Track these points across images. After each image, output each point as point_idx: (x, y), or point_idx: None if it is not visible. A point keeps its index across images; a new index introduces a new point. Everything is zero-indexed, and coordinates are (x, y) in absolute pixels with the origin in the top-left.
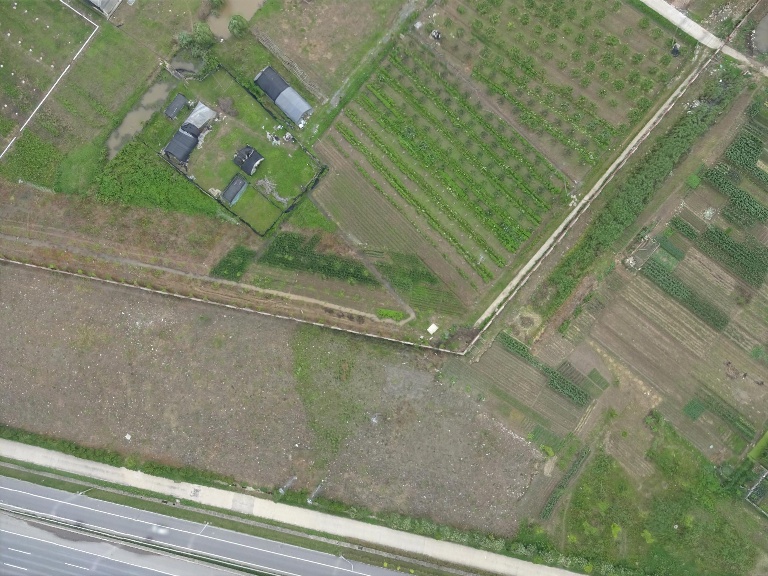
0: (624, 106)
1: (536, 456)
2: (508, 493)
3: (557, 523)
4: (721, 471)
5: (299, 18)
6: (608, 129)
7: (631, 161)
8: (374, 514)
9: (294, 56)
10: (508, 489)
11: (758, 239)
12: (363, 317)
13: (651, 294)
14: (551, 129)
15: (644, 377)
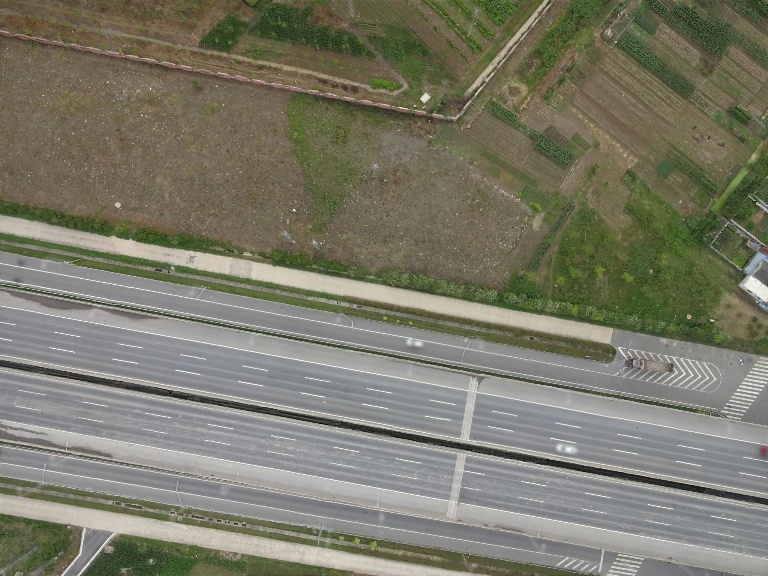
0: None
1: (526, 211)
2: (500, 245)
3: (545, 273)
4: (689, 222)
5: None
6: None
7: None
8: (372, 274)
9: None
10: (500, 241)
11: (719, 16)
12: (357, 87)
13: (627, 65)
14: None
15: (621, 141)
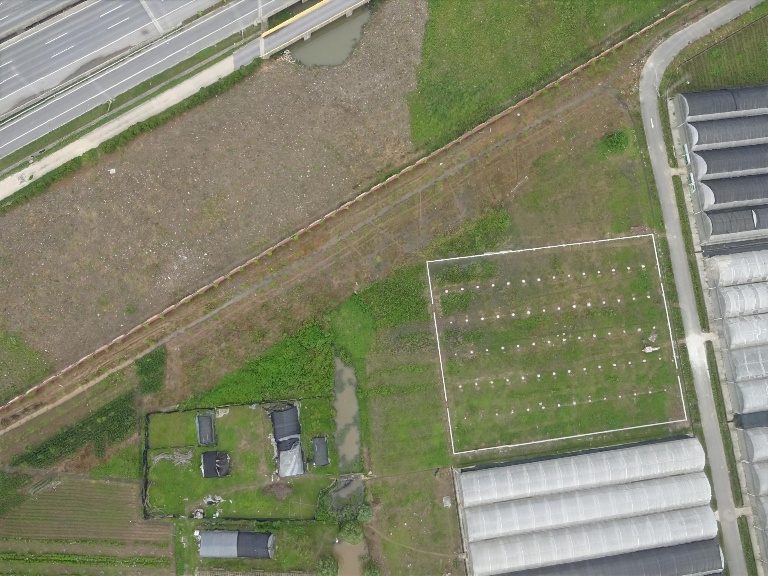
0: None
1: None
2: None
3: None
4: None
5: None
6: None
7: None
8: None
9: None
10: None
11: None
12: (5, 427)
13: None
14: None
15: None
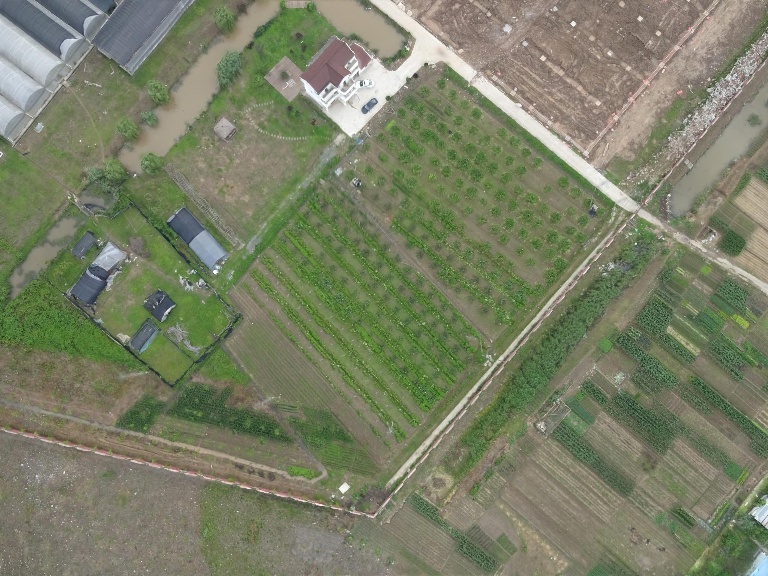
0: (541, 265)
1: None
2: None
3: None
4: None
5: (216, 157)
6: (525, 289)
7: (546, 322)
8: None
9: (210, 197)
10: None
11: (665, 405)
12: (274, 474)
13: (561, 458)
14: (469, 286)
15: (551, 541)
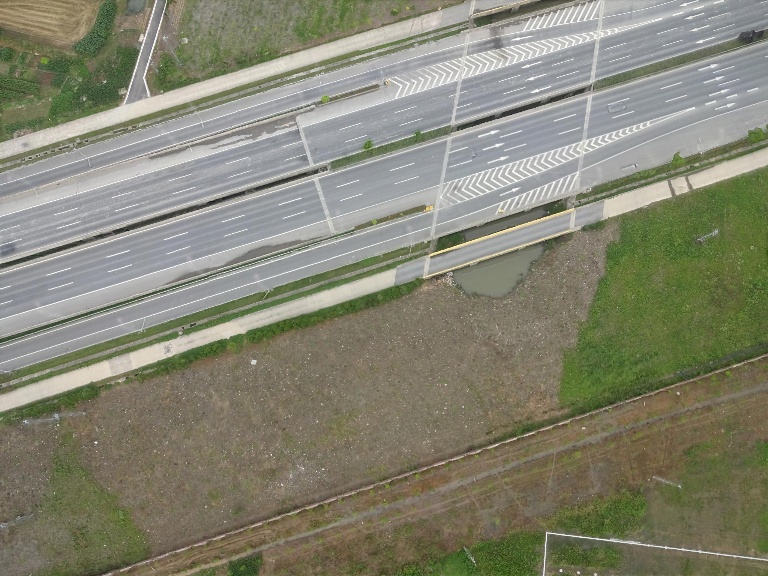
0: None
1: None
2: None
3: None
4: None
5: None
6: None
7: None
8: (0, 422)
9: None
10: None
11: None
12: None
13: None
14: None
15: None
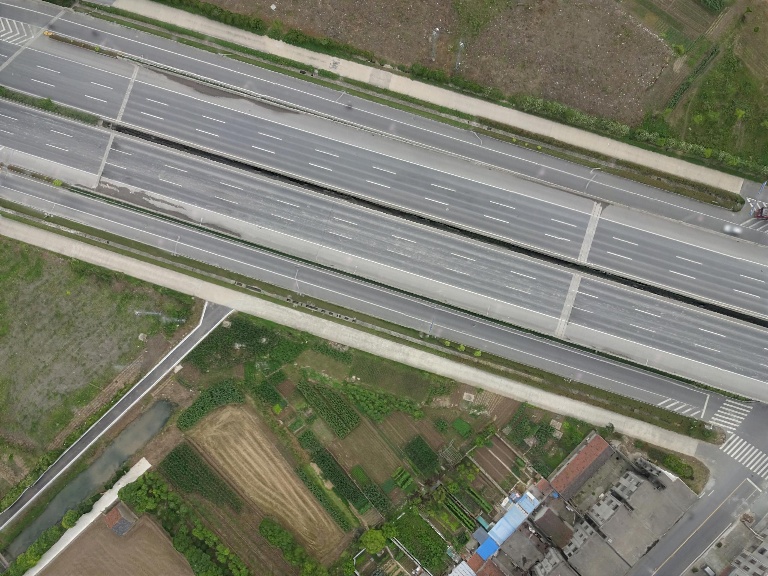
0: None
1: (668, 51)
2: (639, 81)
3: (680, 115)
4: None
5: None
6: None
7: None
8: (506, 98)
9: None
10: (639, 77)
11: None
12: None
13: None
14: None
15: None
